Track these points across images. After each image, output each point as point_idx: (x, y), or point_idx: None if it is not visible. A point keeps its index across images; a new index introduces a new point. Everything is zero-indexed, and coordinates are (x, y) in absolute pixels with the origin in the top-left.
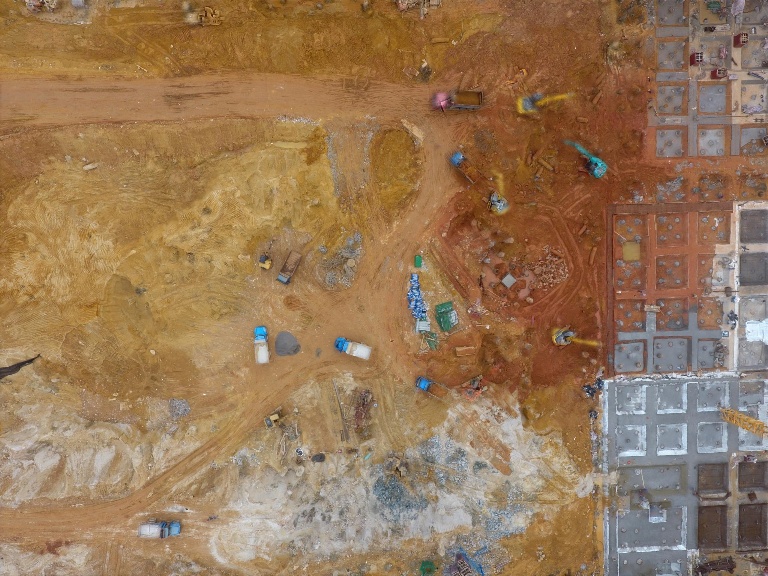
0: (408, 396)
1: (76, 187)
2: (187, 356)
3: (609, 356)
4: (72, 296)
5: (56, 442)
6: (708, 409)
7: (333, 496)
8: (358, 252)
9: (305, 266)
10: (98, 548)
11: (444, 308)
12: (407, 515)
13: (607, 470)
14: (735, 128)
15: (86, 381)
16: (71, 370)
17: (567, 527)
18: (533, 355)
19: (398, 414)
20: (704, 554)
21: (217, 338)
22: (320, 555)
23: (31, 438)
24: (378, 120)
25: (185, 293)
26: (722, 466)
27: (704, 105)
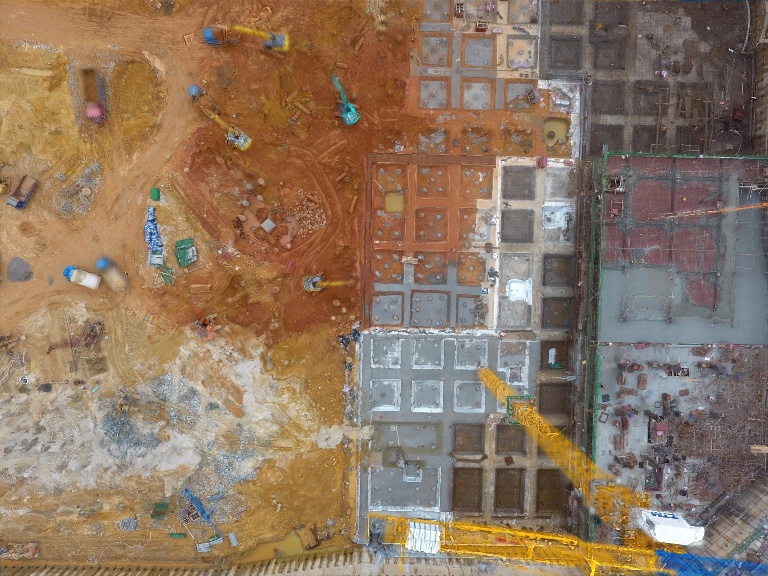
0: (140, 330)
1: None
2: None
3: (365, 307)
4: None
5: None
6: (466, 367)
7: (51, 425)
8: (96, 182)
9: (43, 193)
10: None
11: (184, 244)
12: (134, 452)
13: (360, 424)
14: (499, 82)
15: None
16: None
17: (300, 476)
18: (285, 301)
19: (128, 348)
20: (458, 517)
21: None
22: (43, 488)
23: None
24: (120, 51)
25: None
26: (480, 427)
27: (470, 58)
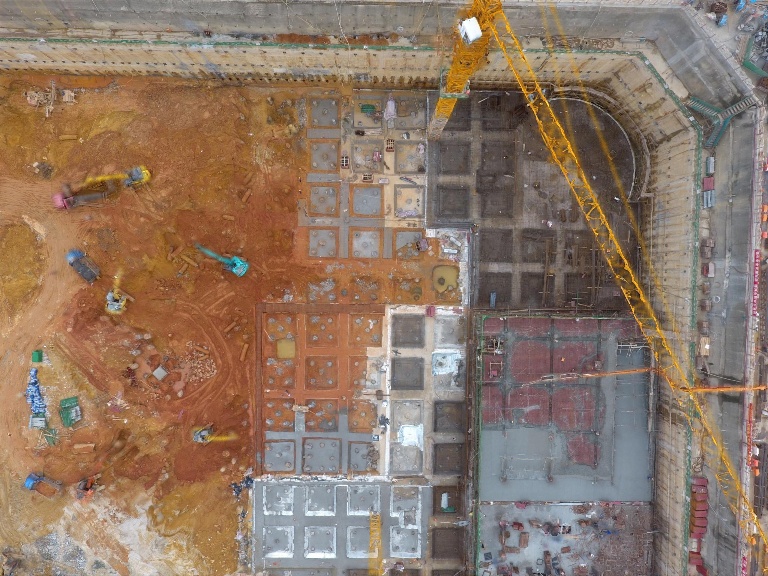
0: (23, 492)
1: None
2: None
3: (257, 454)
4: None
5: None
6: (359, 513)
7: None
8: None
9: None
10: None
11: (68, 403)
12: None
13: (254, 570)
14: (387, 231)
15: None
16: None
17: None
18: (175, 451)
19: (12, 509)
20: None
21: None
22: None
23: None
24: None
25: None
26: (374, 571)
27: (358, 207)
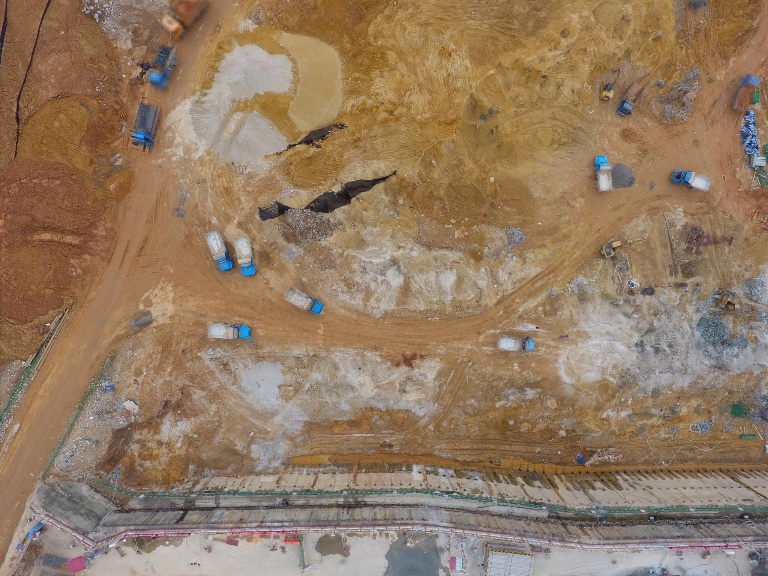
0: (737, 233)
1: (429, 11)
2: (524, 185)
3: None
4: (431, 114)
5: (402, 262)
6: None
7: None
8: (695, 87)
9: (641, 100)
10: (448, 364)
11: None
12: (730, 353)
13: None
14: None
15: (426, 206)
16: (419, 191)
17: None
18: None
19: (727, 250)
20: None
21: (554, 168)
22: (644, 389)
23: (386, 253)
24: None
25: (533, 118)
26: None
27: None
